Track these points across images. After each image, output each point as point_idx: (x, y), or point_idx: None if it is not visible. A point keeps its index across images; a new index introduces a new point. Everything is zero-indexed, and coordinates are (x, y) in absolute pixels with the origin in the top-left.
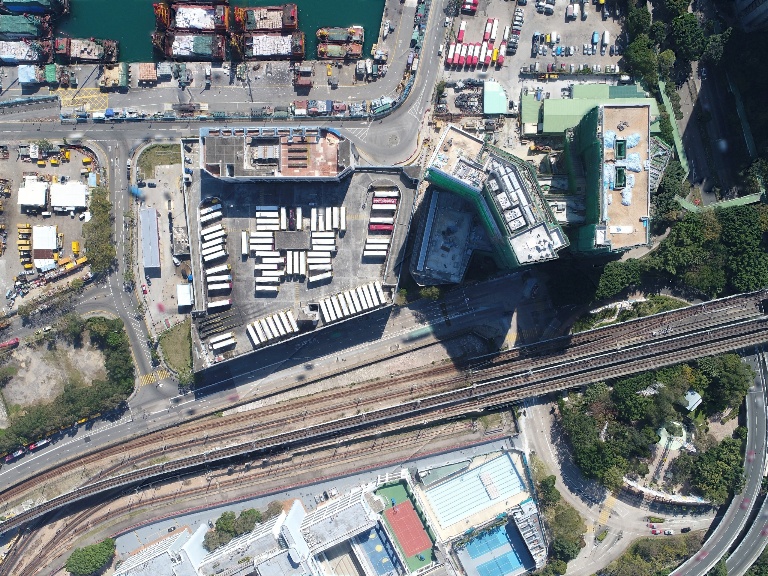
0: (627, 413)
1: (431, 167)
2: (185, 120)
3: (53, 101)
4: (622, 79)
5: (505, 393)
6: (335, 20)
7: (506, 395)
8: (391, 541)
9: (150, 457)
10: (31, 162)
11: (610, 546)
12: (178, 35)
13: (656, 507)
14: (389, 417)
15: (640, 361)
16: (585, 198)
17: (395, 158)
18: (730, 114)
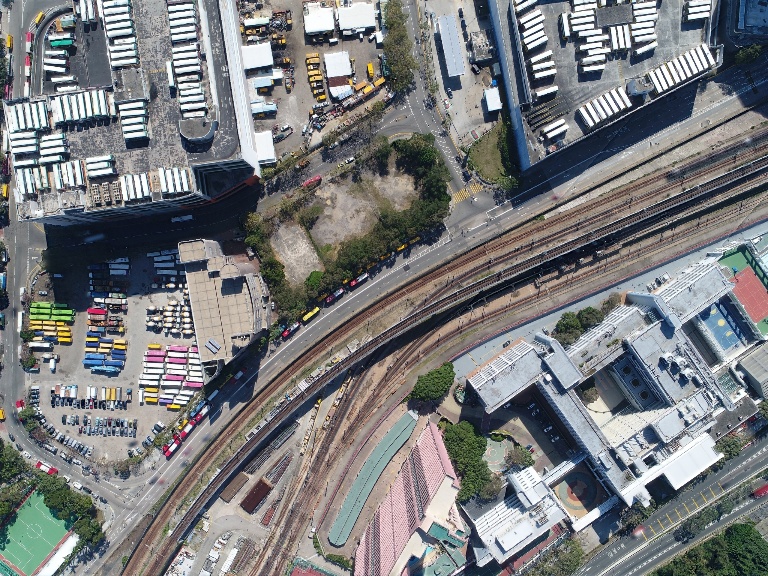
0: None
1: None
2: None
3: None
4: None
5: None
6: None
7: None
8: (743, 306)
9: (475, 274)
10: None
11: None
12: None
13: None
14: (721, 186)
15: None
16: None
17: None
18: None
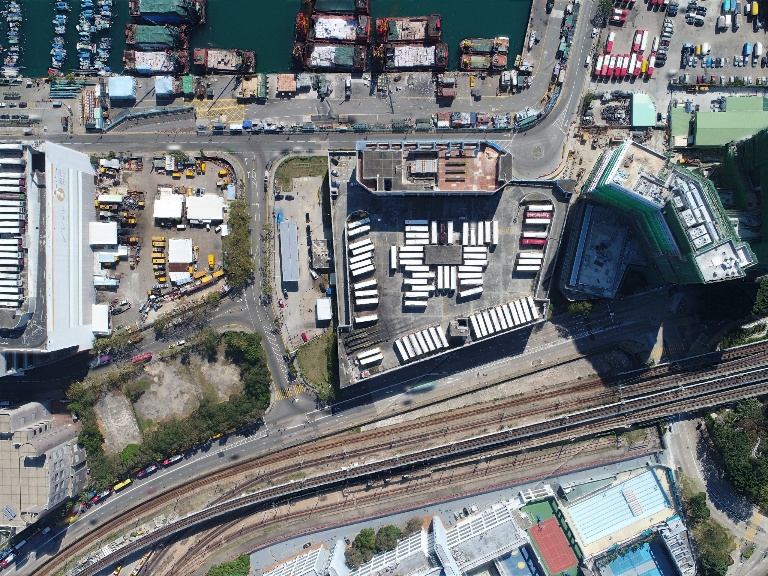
0: None
1: (610, 183)
2: (324, 132)
3: (188, 112)
4: None
5: (653, 409)
6: (478, 31)
7: (655, 411)
8: (538, 559)
9: (286, 473)
10: (165, 174)
11: (756, 563)
12: (318, 46)
13: None
14: (536, 433)
15: None
16: (760, 214)
17: (539, 171)
18: None
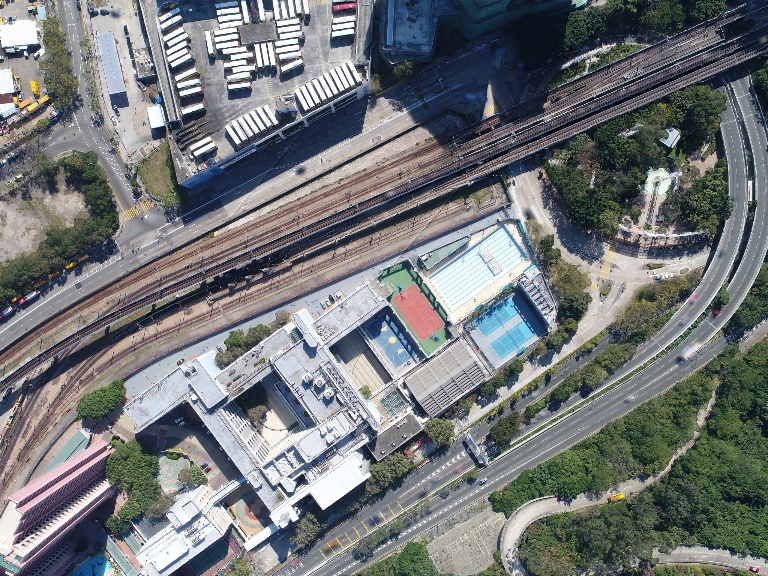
0: (612, 158)
1: None
2: None
3: None
4: None
5: (492, 161)
6: None
7: (493, 163)
8: (403, 324)
9: (147, 292)
10: None
11: (616, 299)
12: None
13: (653, 254)
14: (382, 203)
15: (616, 107)
16: None
17: None
18: None
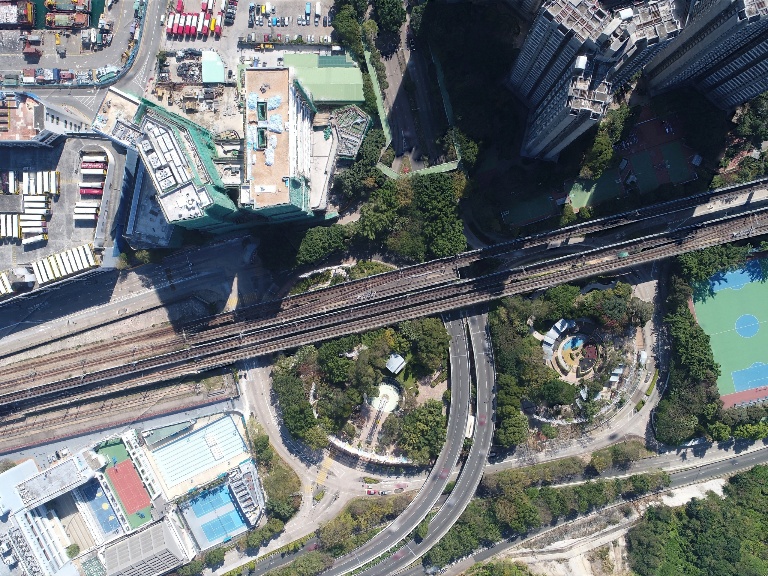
0: (332, 375)
1: (93, 128)
2: None
3: None
4: (333, 49)
5: (221, 355)
6: None
7: (222, 357)
8: (108, 498)
9: None
10: None
11: (327, 506)
12: None
13: (371, 468)
14: (109, 378)
15: (346, 324)
16: None
17: None
18: (432, 84)
